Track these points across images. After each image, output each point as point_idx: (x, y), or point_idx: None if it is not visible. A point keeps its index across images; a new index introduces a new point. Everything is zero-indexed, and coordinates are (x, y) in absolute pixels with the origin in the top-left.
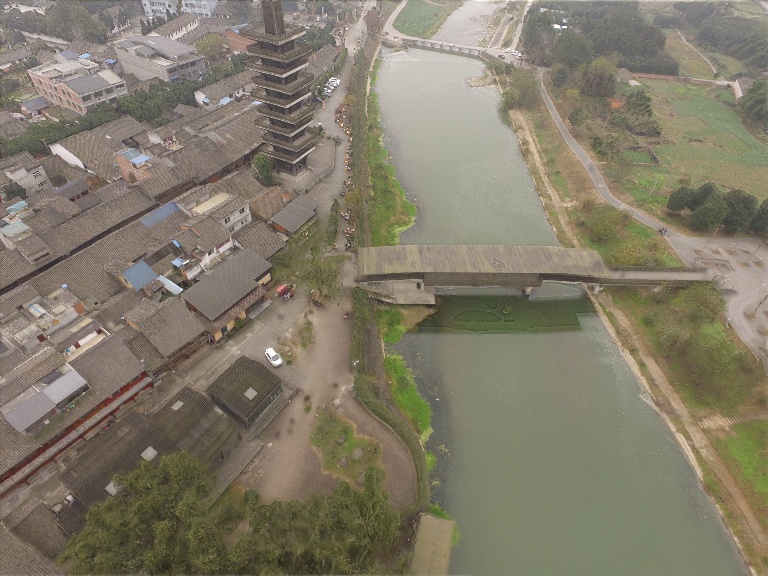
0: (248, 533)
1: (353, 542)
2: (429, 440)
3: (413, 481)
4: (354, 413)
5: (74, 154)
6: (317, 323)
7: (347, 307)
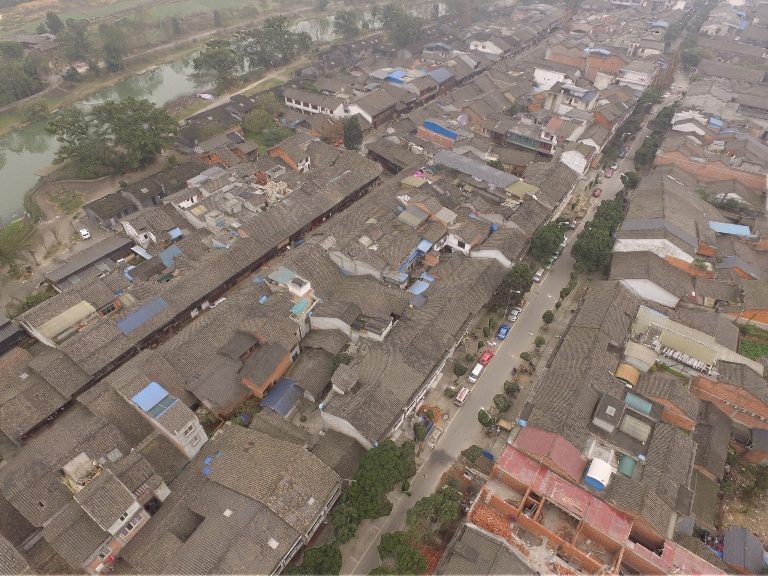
0: (98, 110)
1: (63, 109)
2: (19, 218)
3: (41, 190)
4: (51, 212)
5: (277, 440)
6: (39, 257)
7: (4, 269)
